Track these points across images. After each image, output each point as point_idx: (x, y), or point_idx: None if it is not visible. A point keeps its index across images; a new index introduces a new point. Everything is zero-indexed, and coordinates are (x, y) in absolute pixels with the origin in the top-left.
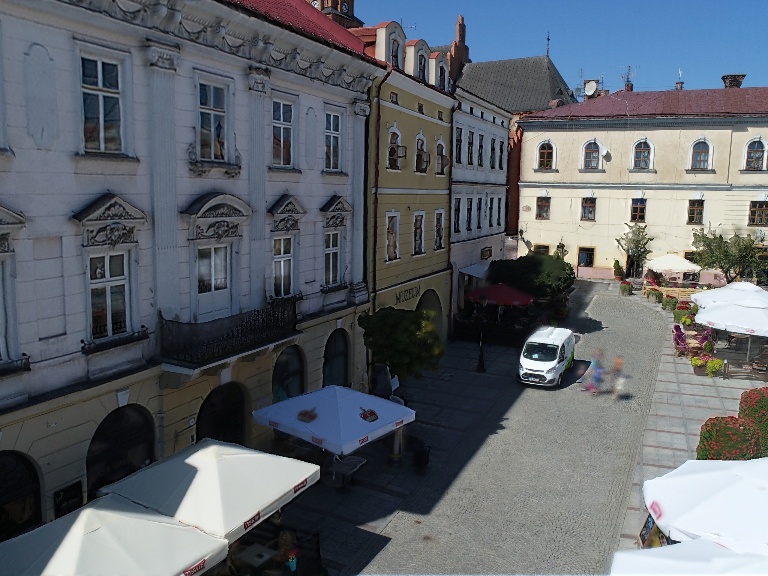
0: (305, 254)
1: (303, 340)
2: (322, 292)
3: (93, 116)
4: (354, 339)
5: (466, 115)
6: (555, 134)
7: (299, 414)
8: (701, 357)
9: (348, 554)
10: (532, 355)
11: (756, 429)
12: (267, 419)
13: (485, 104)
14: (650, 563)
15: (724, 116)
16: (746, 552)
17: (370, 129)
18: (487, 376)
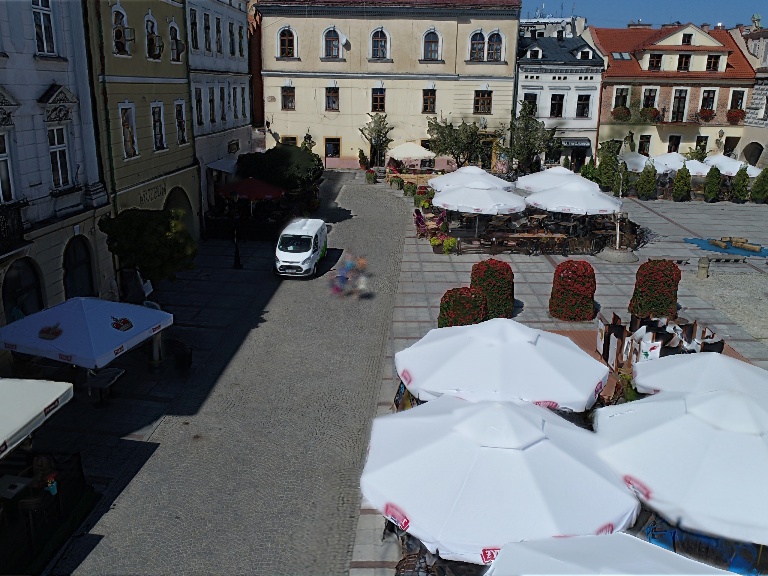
0: (25, 153)
1: (35, 251)
2: (52, 196)
3: None
4: (96, 245)
5: None
6: (295, 20)
7: (40, 332)
8: (439, 237)
9: (115, 467)
10: (287, 247)
11: None
12: (1, 342)
13: None
14: (404, 423)
15: (450, 7)
16: (480, 401)
17: (88, 6)
18: (244, 272)
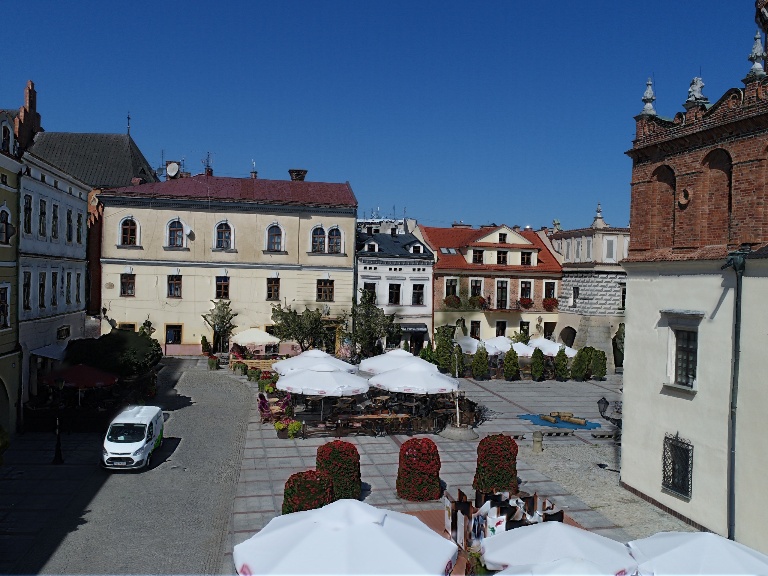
0: None
1: None
2: None
3: None
4: None
5: (36, 182)
6: (138, 211)
7: None
8: (283, 421)
9: None
10: (117, 437)
11: (331, 479)
12: None
13: (59, 173)
14: None
15: (292, 204)
16: None
17: None
18: (65, 467)
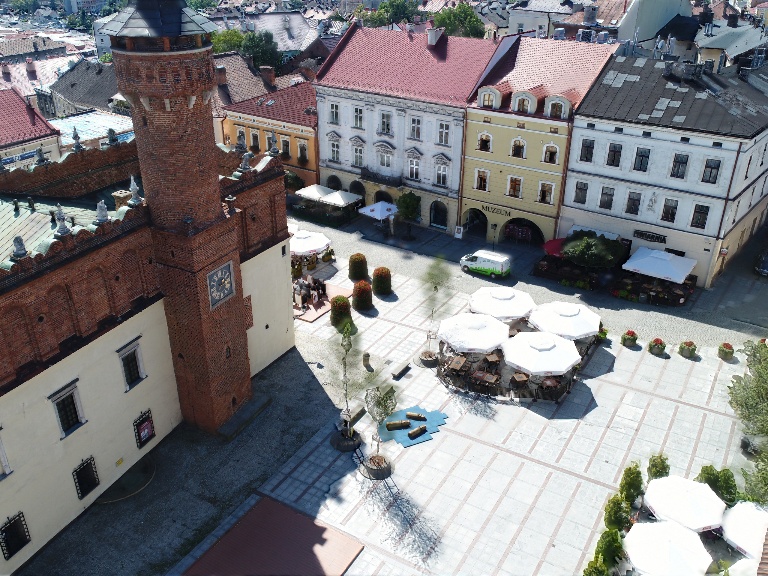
0: (426, 169)
1: None
2: None
3: (357, 120)
4: None
5: None
6: None
7: None
8: None
9: None
10: None
11: None
12: None
13: (646, 127)
14: None
15: None
16: None
17: None
18: None
